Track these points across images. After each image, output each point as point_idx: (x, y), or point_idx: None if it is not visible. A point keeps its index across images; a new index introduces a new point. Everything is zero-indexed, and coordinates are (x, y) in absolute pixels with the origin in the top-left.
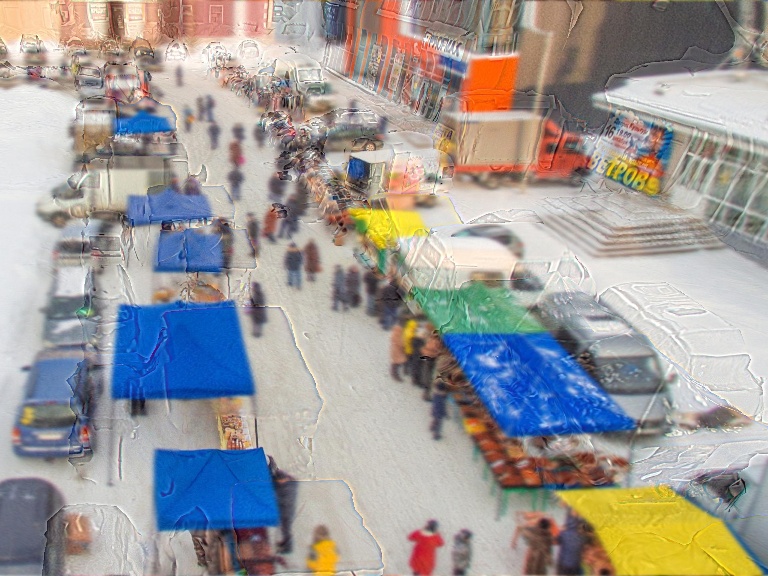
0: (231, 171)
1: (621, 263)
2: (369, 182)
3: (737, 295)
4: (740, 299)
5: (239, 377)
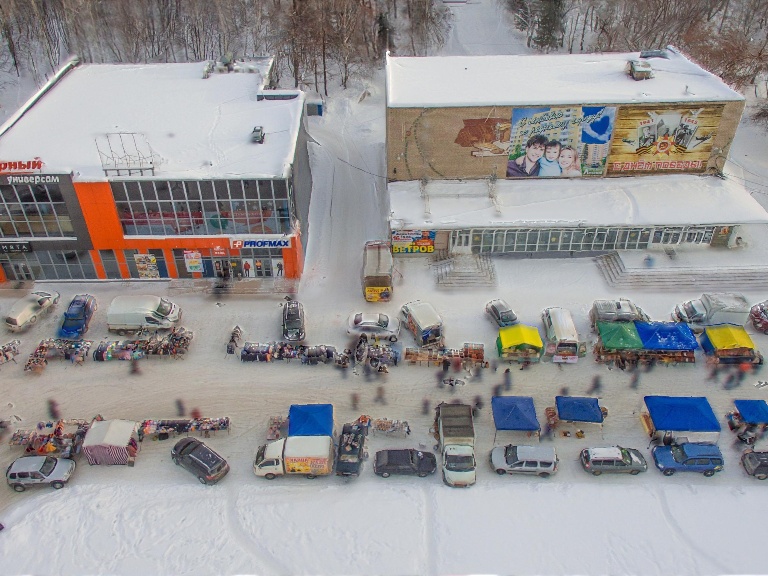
0: (372, 394)
1: (516, 290)
2: (439, 338)
3: (544, 276)
4: (547, 276)
5: (706, 412)
